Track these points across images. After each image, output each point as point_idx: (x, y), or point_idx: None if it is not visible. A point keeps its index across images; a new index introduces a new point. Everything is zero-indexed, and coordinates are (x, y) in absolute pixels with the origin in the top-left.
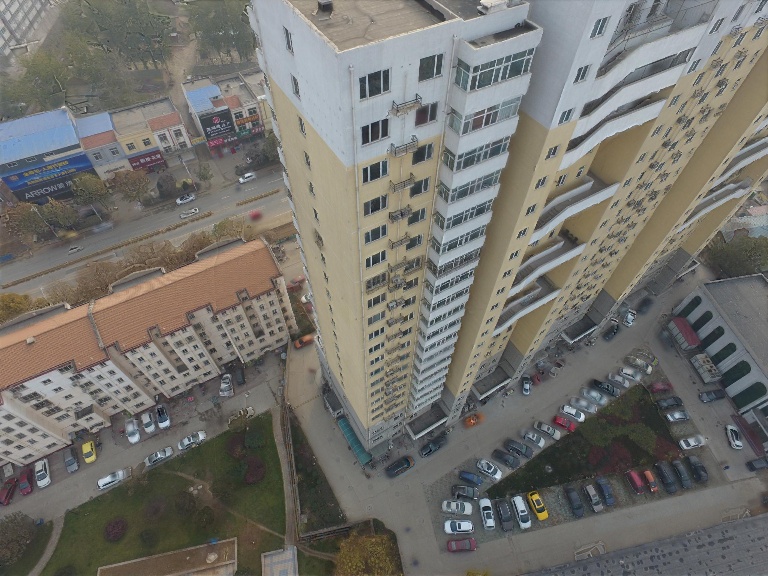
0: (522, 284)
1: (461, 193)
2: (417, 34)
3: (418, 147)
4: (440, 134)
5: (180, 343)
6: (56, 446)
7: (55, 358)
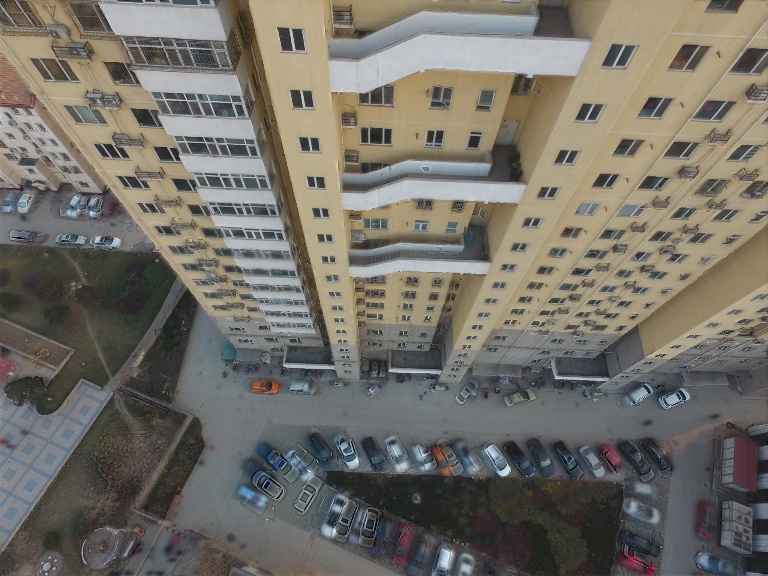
0: (372, 196)
1: None
2: None
3: None
4: None
5: None
6: (4, 183)
7: None
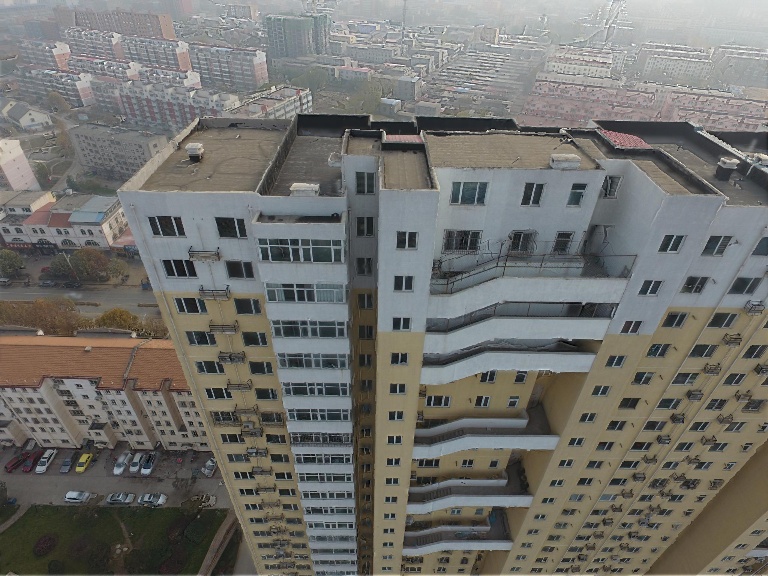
0: (428, 505)
1: (295, 362)
2: (203, 195)
3: (239, 298)
4: (264, 294)
5: (185, 404)
6: (68, 444)
7: (92, 370)
